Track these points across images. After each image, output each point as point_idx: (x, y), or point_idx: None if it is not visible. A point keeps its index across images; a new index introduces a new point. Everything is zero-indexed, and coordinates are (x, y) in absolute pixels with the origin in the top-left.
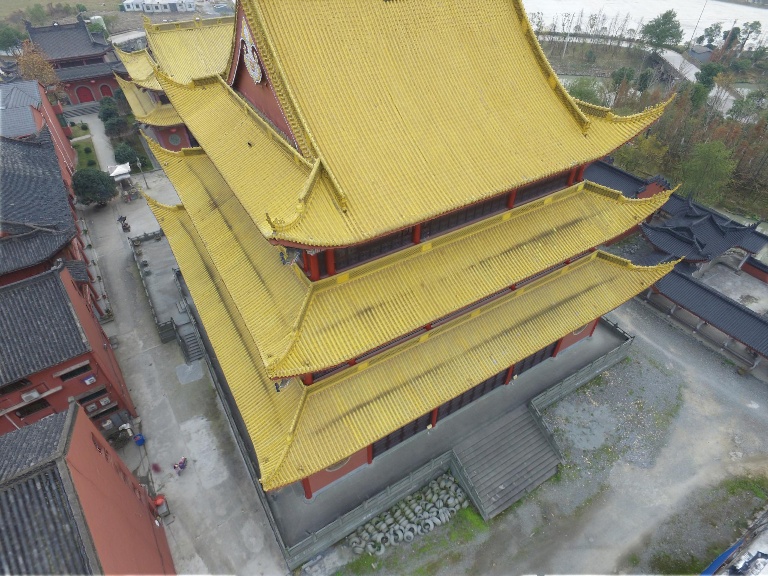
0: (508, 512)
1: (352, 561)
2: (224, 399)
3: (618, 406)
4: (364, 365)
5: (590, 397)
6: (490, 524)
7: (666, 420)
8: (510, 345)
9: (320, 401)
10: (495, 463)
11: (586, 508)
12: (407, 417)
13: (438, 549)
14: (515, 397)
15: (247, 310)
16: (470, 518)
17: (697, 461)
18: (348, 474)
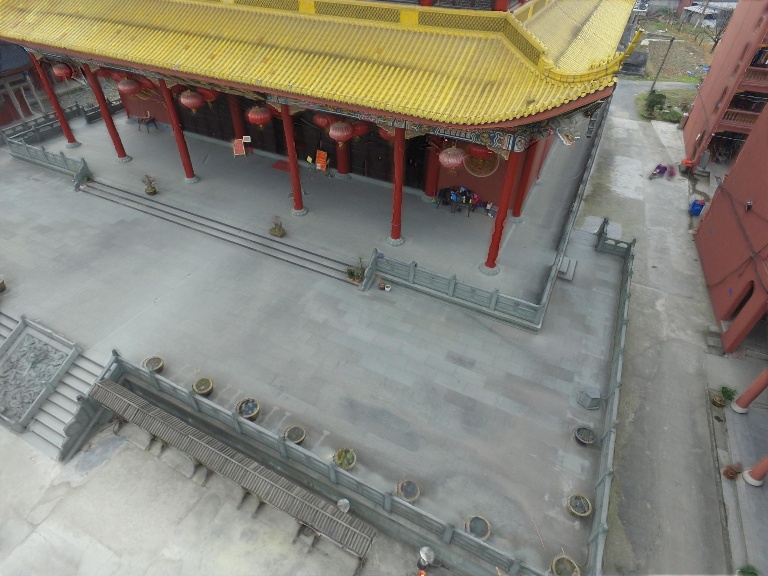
0: None
1: None
2: None
3: None
4: None
5: None
6: None
7: None
8: None
9: None
10: None
11: None
12: None
13: None
14: None
15: None
16: None
17: None
18: None
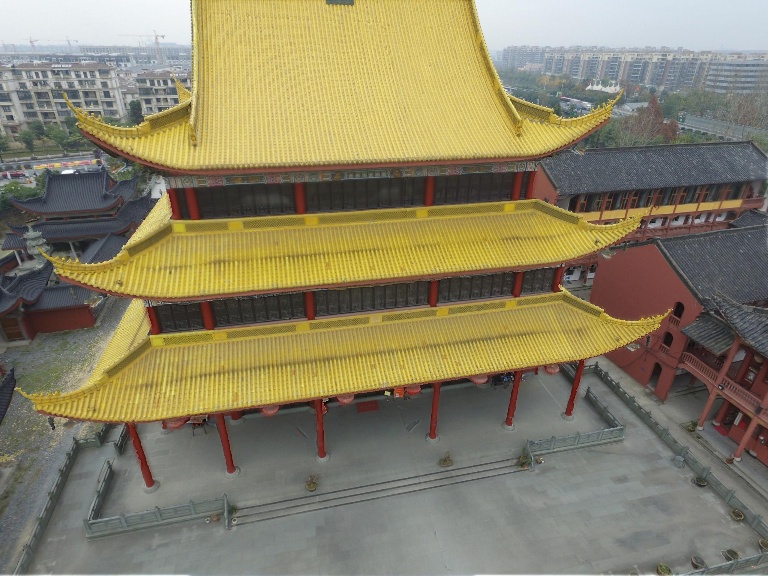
0: None
1: None
2: None
3: None
4: None
5: None
6: None
7: None
8: None
9: None
10: None
11: None
12: None
13: None
14: None
15: None
16: None
17: None
18: None
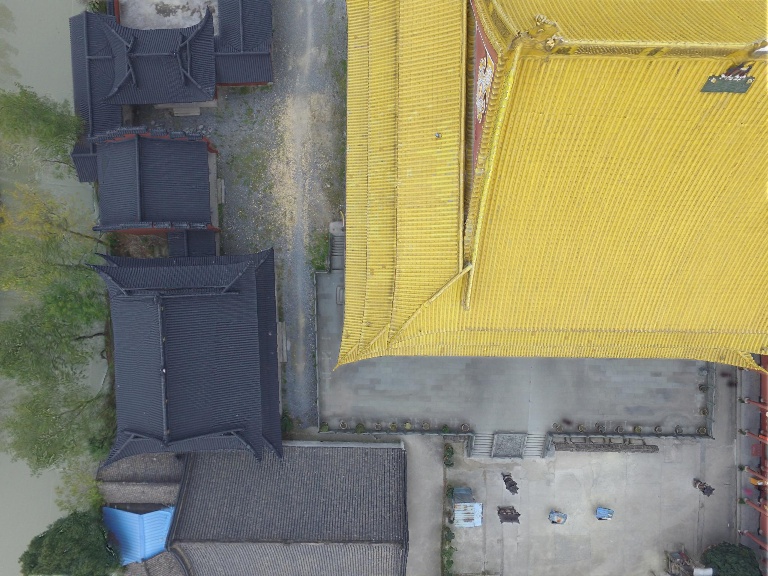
0: None
1: None
2: None
3: None
4: None
5: None
6: None
7: None
8: None
9: None
10: None
11: None
12: None
13: None
14: None
15: None
16: None
17: None
18: None
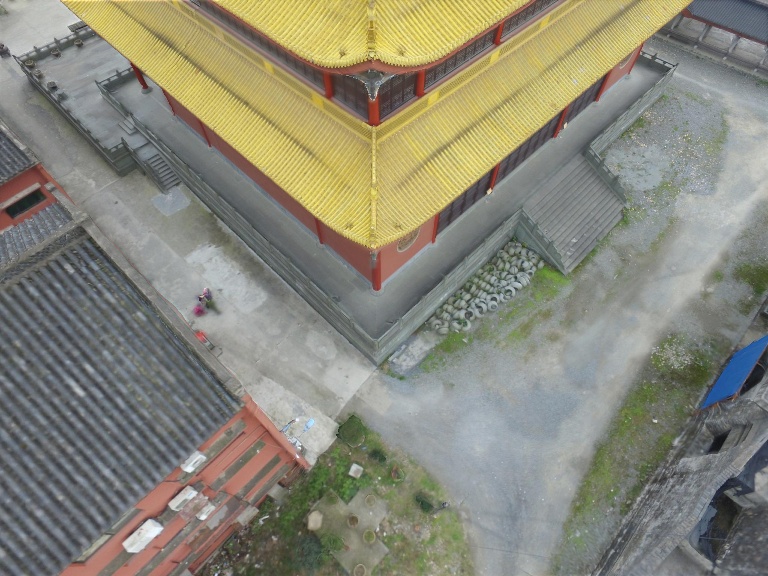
0: (585, 263)
1: (440, 342)
2: (234, 211)
3: (667, 143)
4: (434, 96)
5: (637, 140)
6: (571, 277)
7: (717, 147)
8: (587, 61)
9: (392, 149)
10: (563, 218)
11: (661, 242)
12: (497, 155)
13: (526, 311)
14: (567, 149)
15: (269, 22)
16: (549, 276)
17: (755, 178)
18: (413, 257)
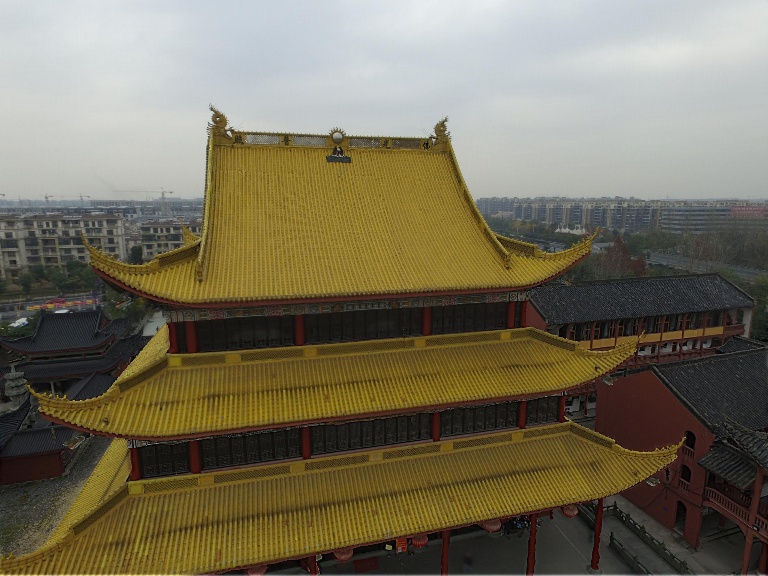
0: None
1: None
2: None
3: None
4: None
5: None
6: None
7: None
8: None
9: None
10: None
11: None
12: None
13: None
14: None
15: None
16: None
17: None
18: None
